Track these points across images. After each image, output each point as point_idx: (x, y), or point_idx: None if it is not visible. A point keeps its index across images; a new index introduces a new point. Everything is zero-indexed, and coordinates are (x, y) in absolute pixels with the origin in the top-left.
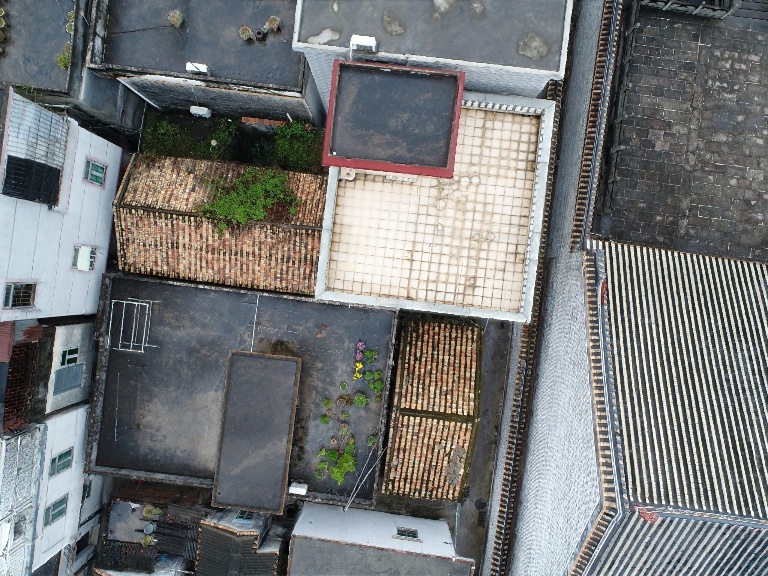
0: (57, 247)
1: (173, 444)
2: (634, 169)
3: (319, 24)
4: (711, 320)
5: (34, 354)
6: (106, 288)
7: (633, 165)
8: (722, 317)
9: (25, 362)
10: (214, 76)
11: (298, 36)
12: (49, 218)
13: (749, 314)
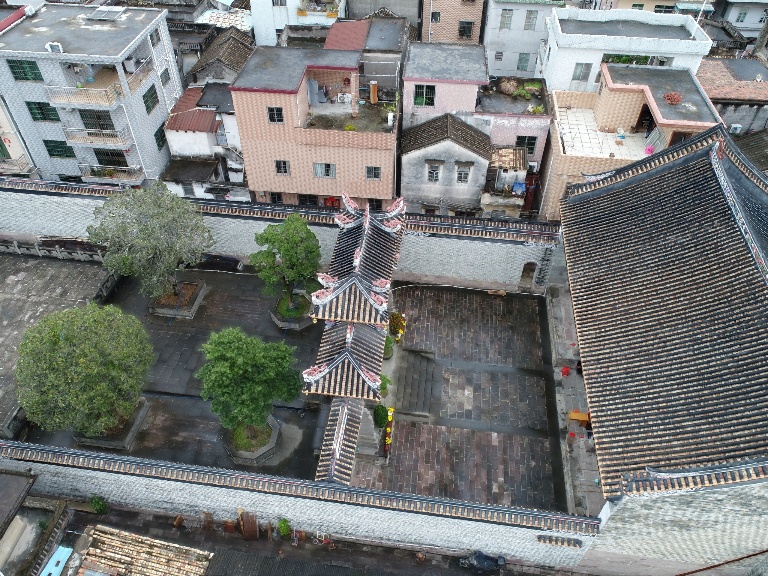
0: None
1: None
2: (3, 265)
3: (50, 8)
4: None
5: None
6: None
7: (6, 264)
8: None
9: None
10: None
11: (47, 4)
12: (45, 1)
13: None
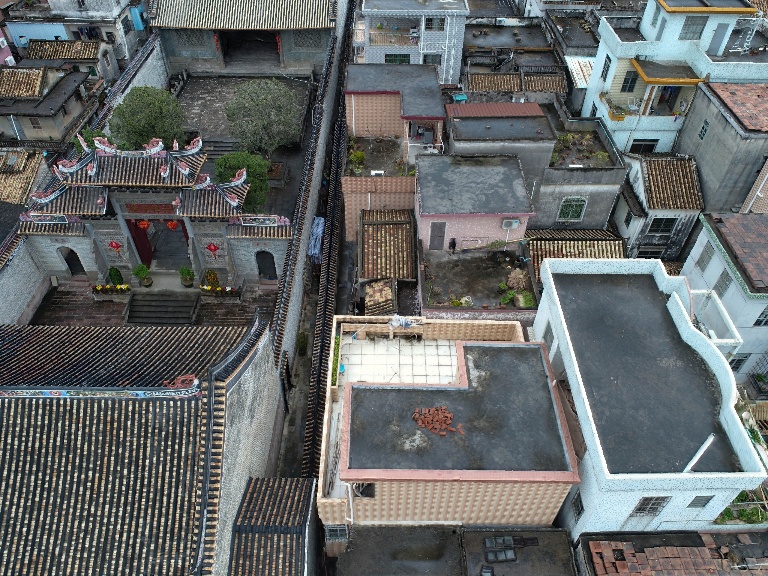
0: None
1: (482, 2)
2: None
3: None
4: (289, 3)
5: None
6: None
7: None
8: (285, 4)
9: None
10: (495, 27)
11: None
12: None
13: (273, 7)
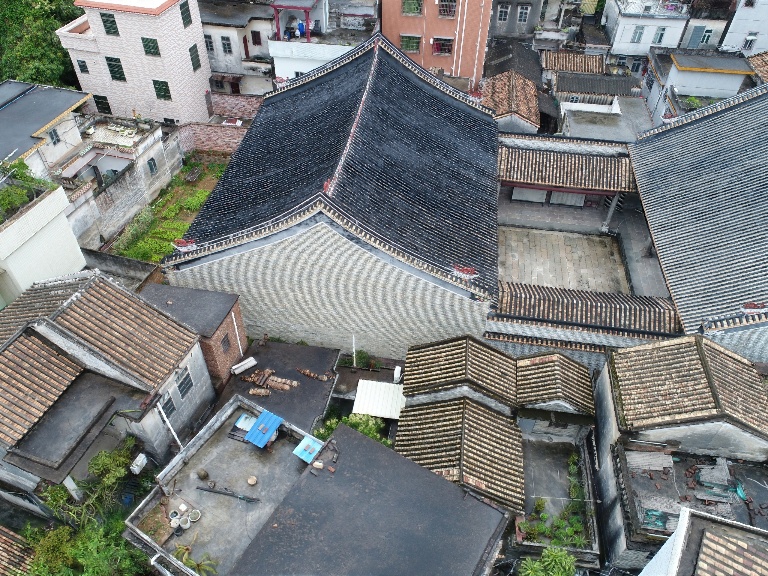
0: (763, 20)
1: None
2: None
3: None
4: None
5: (724, 8)
6: (734, 53)
7: None
8: None
9: (723, 3)
10: None
11: None
12: None
13: None
